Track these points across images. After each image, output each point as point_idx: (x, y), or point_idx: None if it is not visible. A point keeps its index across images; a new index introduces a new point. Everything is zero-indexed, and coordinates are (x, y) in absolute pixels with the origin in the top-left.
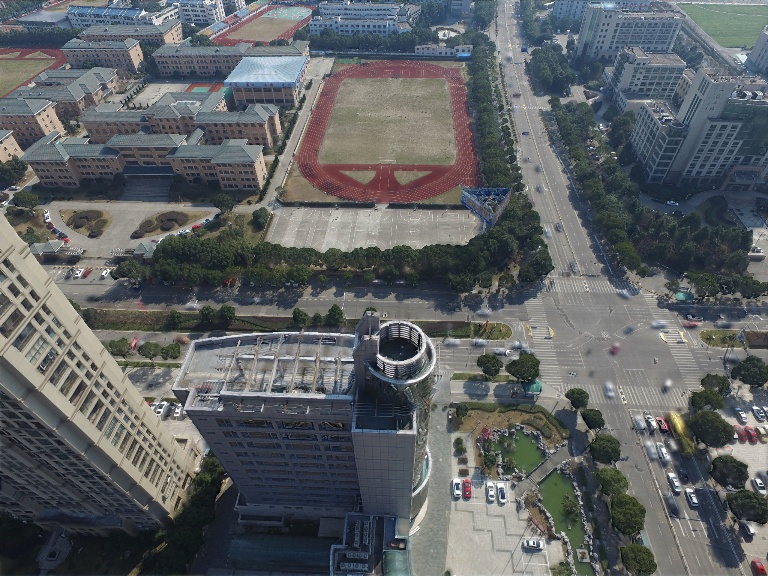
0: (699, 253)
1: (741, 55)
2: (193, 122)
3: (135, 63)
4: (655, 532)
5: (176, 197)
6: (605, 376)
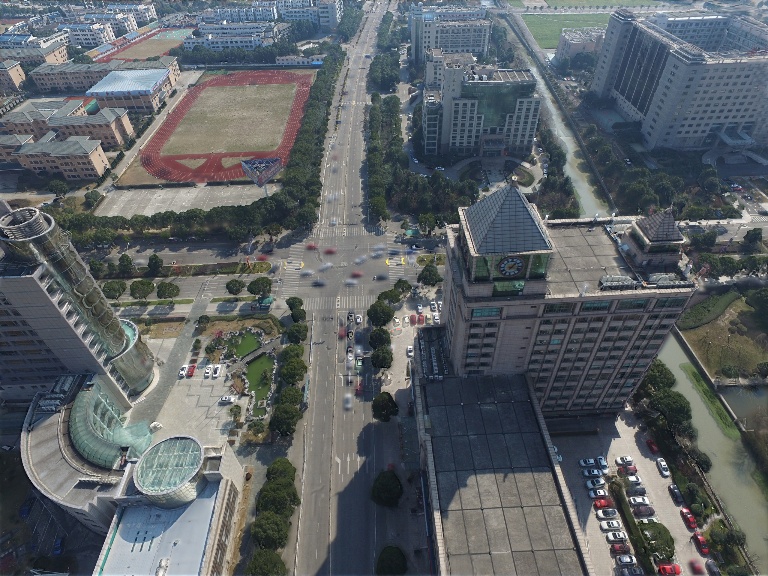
0: (436, 201)
1: (550, 54)
2: (46, 125)
3: (16, 82)
4: (322, 385)
5: (24, 188)
6: (331, 291)
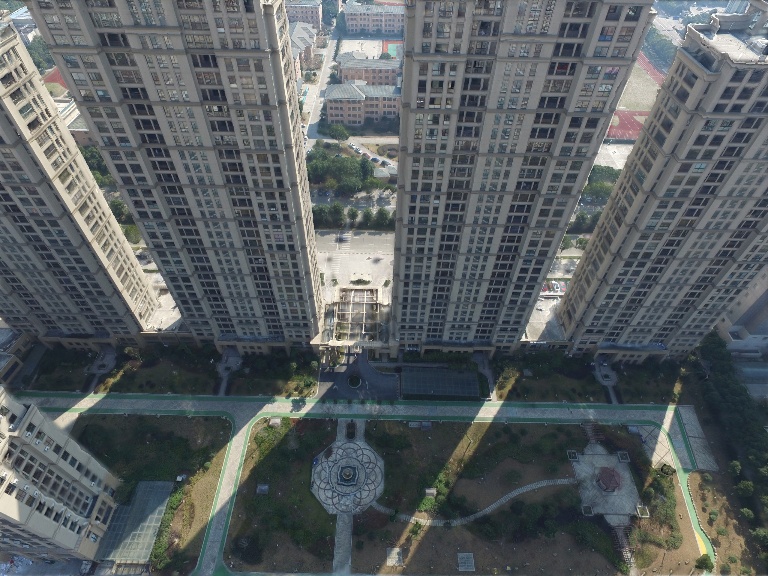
0: None
1: None
2: None
3: (320, 20)
4: None
5: None
6: None
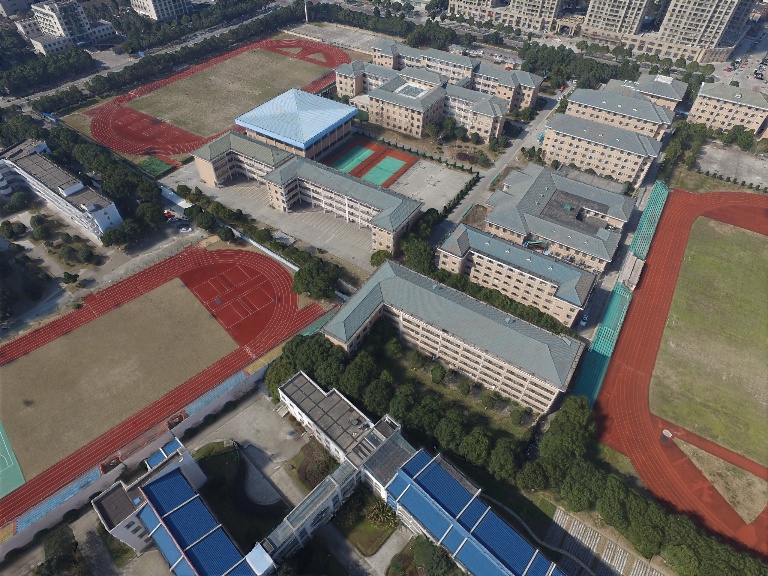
0: None
1: None
2: None
3: None
4: None
5: None
6: None
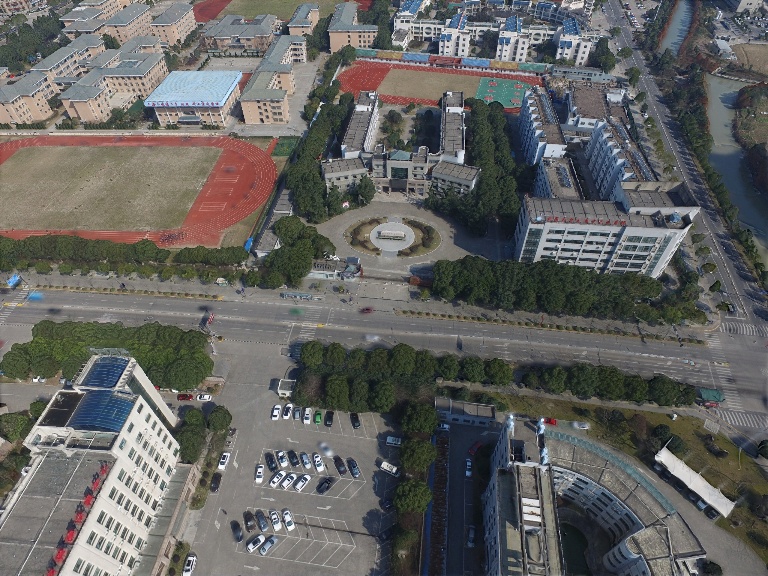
0: None
1: None
2: None
3: None
4: None
5: None
6: None
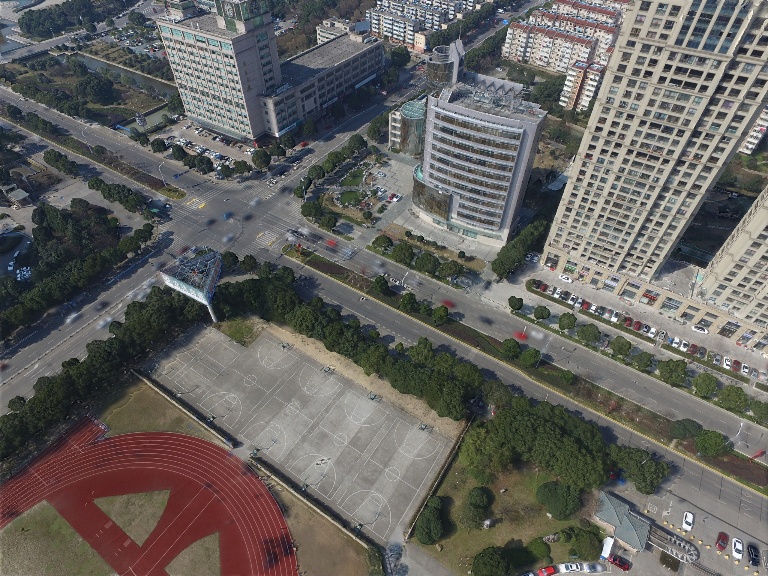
0: None
1: None
2: None
3: None
4: None
5: None
6: (265, 205)
